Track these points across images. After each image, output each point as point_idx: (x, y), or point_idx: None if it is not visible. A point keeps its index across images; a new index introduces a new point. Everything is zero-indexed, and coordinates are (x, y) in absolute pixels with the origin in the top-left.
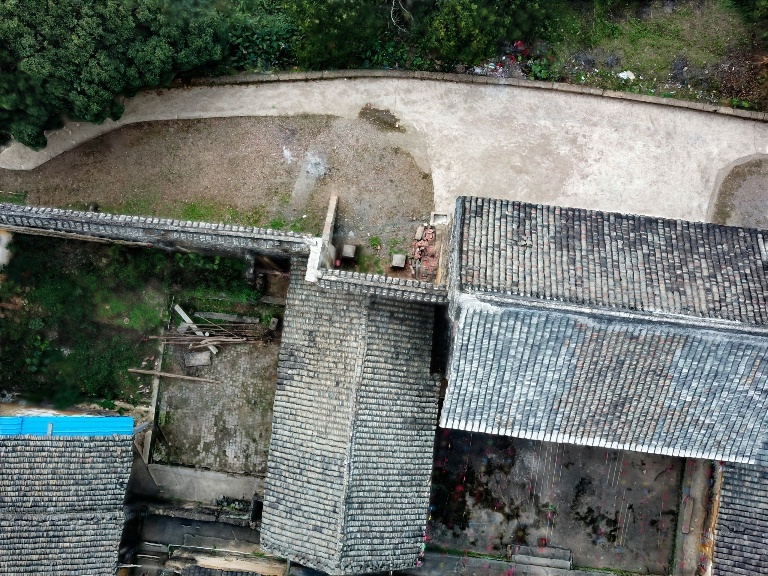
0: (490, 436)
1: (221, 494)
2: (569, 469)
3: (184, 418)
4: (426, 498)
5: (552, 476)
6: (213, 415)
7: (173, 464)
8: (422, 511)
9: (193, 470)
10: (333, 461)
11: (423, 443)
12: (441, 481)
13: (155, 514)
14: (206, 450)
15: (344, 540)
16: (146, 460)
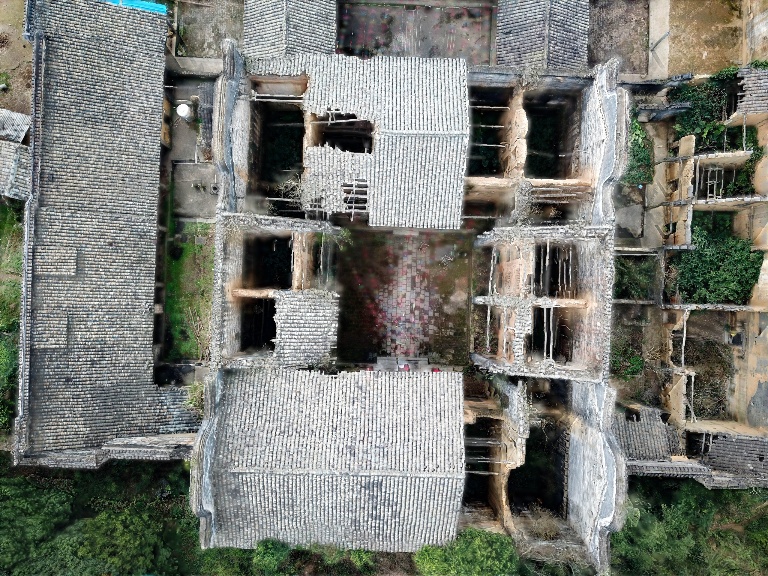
0: (376, 26)
1: (220, 70)
2: (424, 42)
3: (194, 29)
4: (334, 33)
5: (415, 47)
6: (211, 26)
7: (190, 56)
8: (332, 40)
9: (202, 58)
10: (278, 3)
11: (329, 1)
12: (349, 55)
13: (182, 74)
14: (209, 47)
15: (287, 43)
16: (174, 54)
